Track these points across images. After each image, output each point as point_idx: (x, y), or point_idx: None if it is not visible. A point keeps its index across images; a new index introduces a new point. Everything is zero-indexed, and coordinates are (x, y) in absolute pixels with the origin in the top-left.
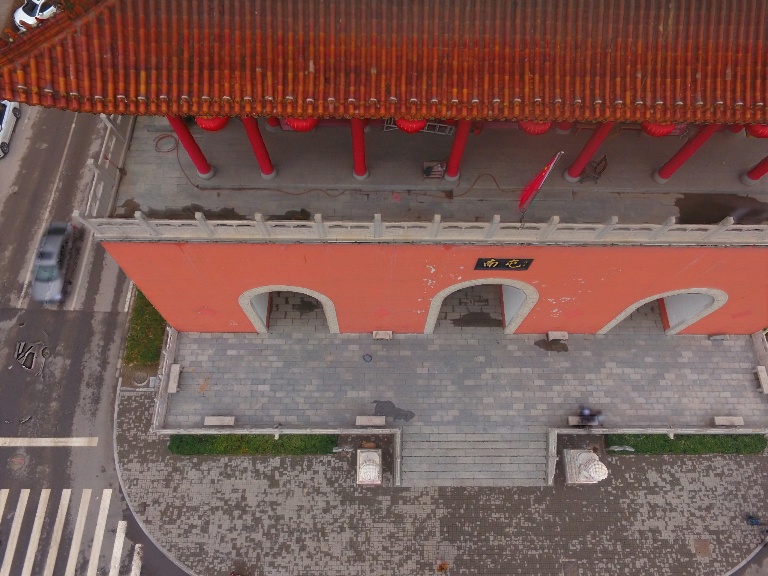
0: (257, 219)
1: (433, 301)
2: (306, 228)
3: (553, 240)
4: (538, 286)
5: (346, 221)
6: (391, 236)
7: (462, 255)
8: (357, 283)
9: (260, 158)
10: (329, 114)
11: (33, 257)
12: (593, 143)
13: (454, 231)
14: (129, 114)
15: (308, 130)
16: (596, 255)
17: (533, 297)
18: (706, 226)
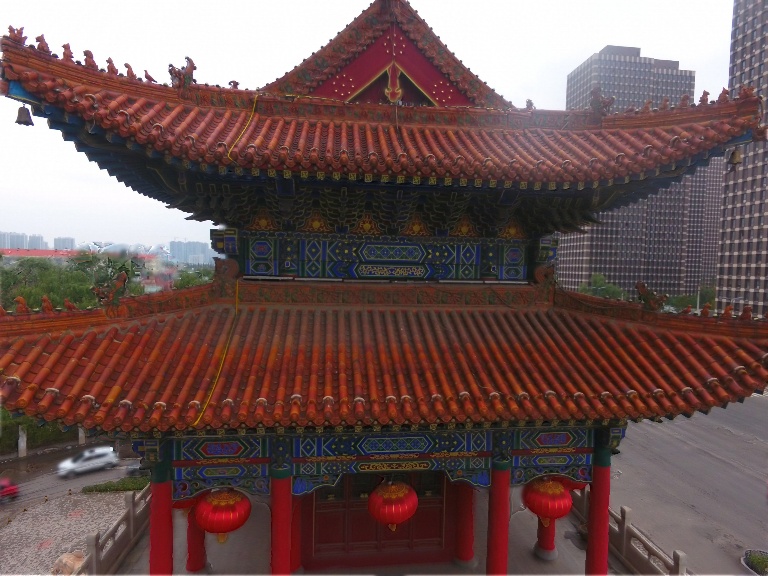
0: None
1: None
2: None
3: None
4: None
5: None
6: None
7: None
8: None
9: None
10: None
11: None
12: None
13: None
14: None
15: None
16: None
17: None
18: None
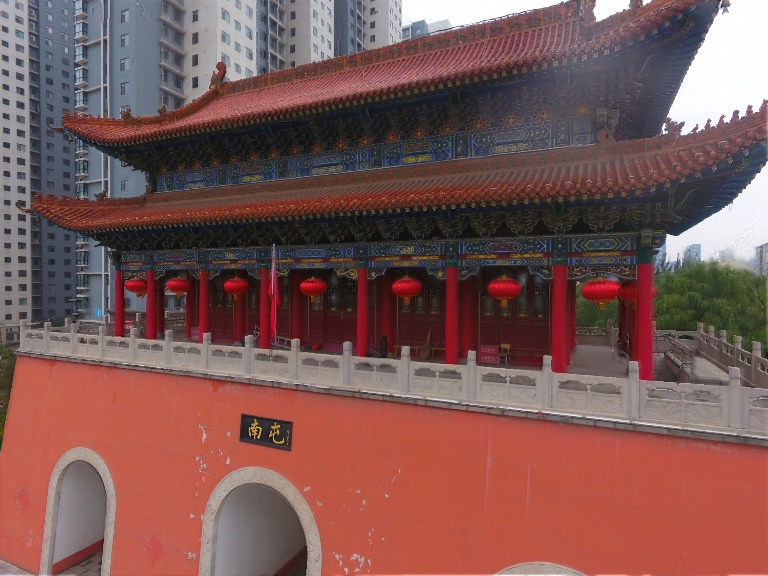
0: (100, 328)
1: (204, 524)
2: (125, 348)
3: (302, 381)
4: (313, 504)
5: (150, 339)
6: (176, 365)
7: (228, 406)
8: (142, 457)
9: (147, 321)
10: (154, 221)
11: None
12: (358, 307)
13: (221, 360)
14: (79, 229)
15: (174, 288)
16: (356, 423)
17: (314, 540)
18: (452, 365)
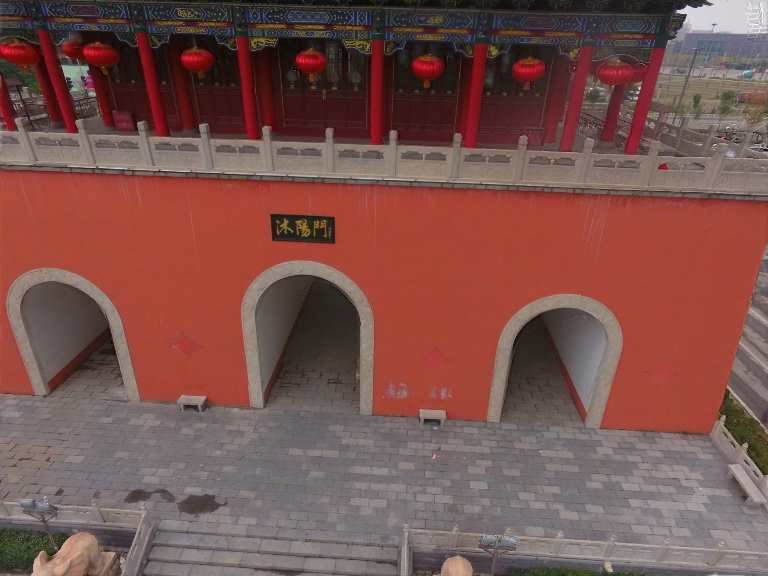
0: None
1: None
2: None
3: None
4: None
5: None
6: None
7: None
8: None
9: None
10: None
11: (765, 320)
12: None
13: None
14: None
15: None
16: None
17: None
18: None
